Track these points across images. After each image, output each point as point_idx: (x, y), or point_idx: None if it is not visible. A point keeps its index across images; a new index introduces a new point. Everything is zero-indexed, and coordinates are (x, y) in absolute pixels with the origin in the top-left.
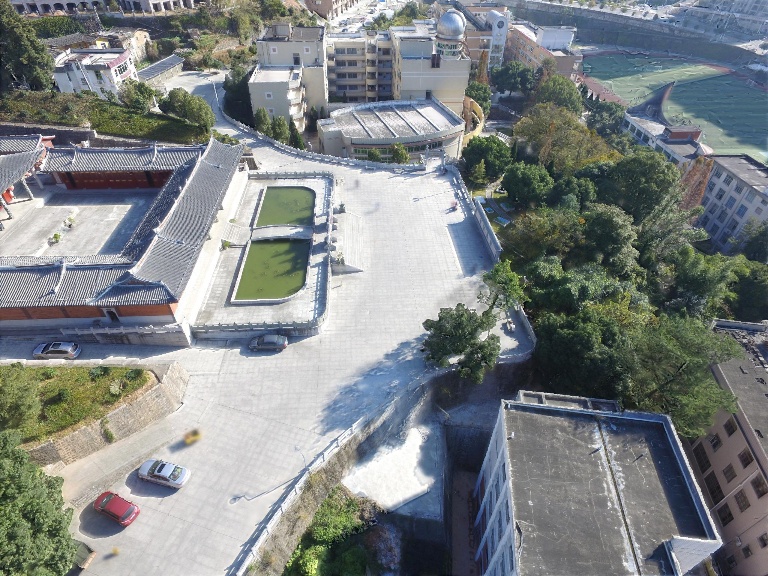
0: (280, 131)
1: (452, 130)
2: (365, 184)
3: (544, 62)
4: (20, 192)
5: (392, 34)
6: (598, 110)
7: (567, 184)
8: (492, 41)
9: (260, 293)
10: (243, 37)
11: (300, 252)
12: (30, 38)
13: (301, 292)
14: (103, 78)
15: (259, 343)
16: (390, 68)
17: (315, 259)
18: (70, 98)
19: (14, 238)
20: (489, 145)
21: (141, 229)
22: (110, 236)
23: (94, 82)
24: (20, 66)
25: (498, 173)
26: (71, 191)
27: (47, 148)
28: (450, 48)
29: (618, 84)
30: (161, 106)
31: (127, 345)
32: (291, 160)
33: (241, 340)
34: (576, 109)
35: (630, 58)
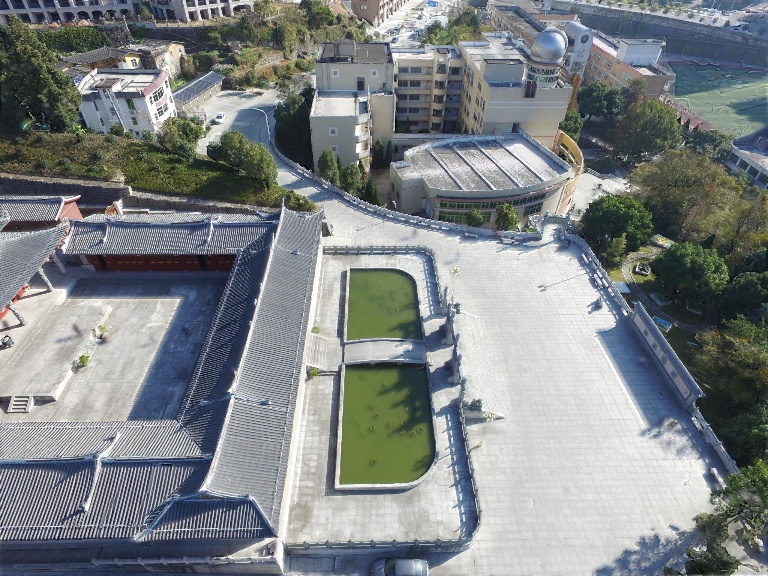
0: (352, 181)
1: (558, 179)
2: (470, 261)
3: (633, 83)
4: (36, 278)
5: (465, 51)
6: (697, 140)
7: (762, 283)
8: (573, 58)
9: (374, 468)
10: (288, 50)
11: (415, 387)
12: (51, 69)
13: (433, 469)
14: (136, 107)
15: (388, 574)
16: (459, 89)
17: (438, 400)
18: (99, 143)
19: (26, 361)
20: (629, 213)
21: (204, 370)
22: (155, 356)
23: (125, 112)
24: (38, 103)
25: (637, 247)
26: (101, 274)
27: (71, 221)
28: (546, 73)
29: (695, 101)
30: (210, 152)
31: (190, 575)
32: (369, 221)
33: (355, 558)
34: (675, 140)
35: (700, 70)
